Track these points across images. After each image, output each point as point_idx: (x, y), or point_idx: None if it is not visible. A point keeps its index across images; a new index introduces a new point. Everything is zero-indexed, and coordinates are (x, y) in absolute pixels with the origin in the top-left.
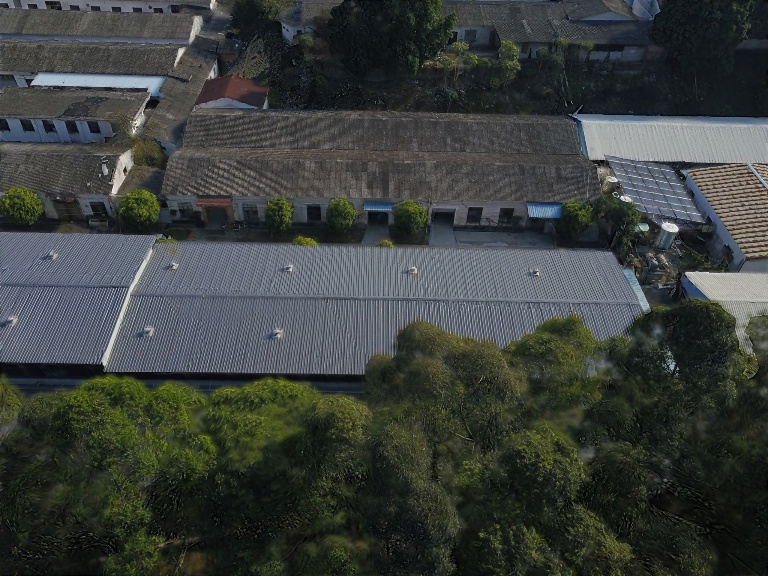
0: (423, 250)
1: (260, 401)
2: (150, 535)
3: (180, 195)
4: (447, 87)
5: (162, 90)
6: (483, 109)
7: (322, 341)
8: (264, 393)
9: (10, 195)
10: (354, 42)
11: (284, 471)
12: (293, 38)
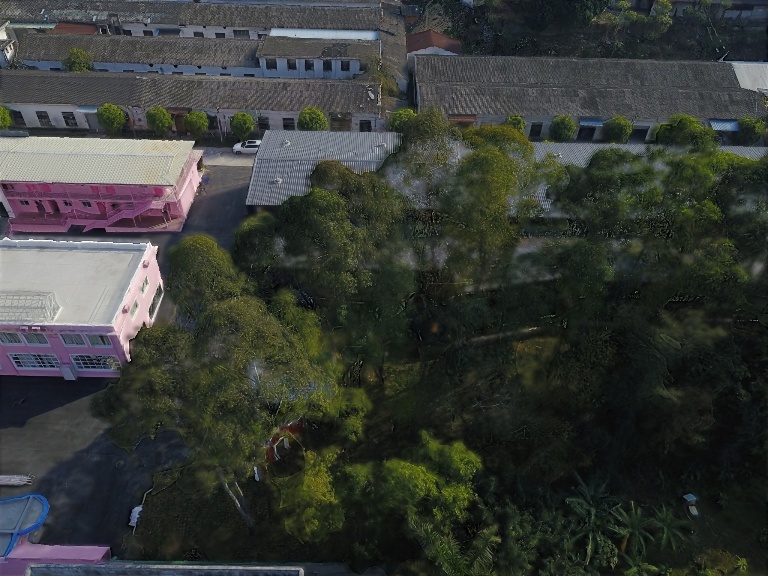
0: None
1: None
2: (715, 204)
3: None
4: (608, 40)
5: (381, 40)
6: (639, 58)
7: None
8: None
9: (308, 112)
10: None
11: None
12: (474, 1)
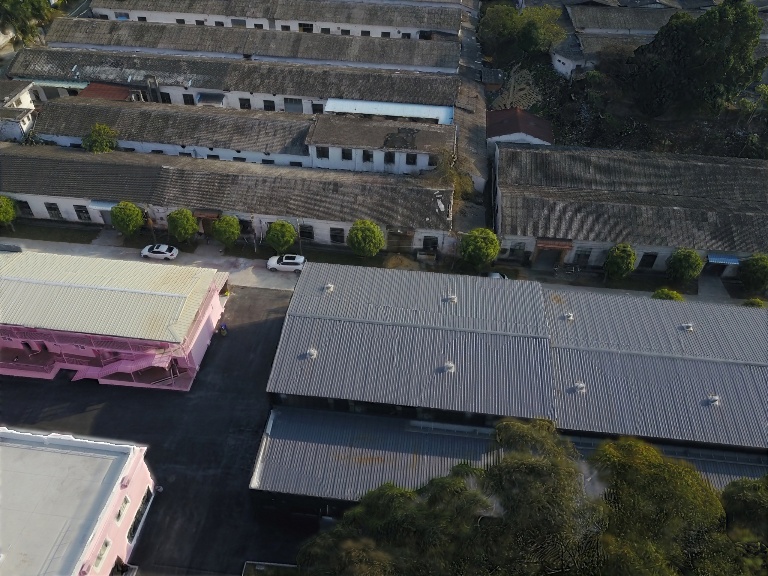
0: None
1: None
2: None
3: (520, 235)
4: (739, 130)
5: (456, 122)
6: None
7: (764, 412)
8: None
9: (361, 227)
10: (660, 82)
11: None
12: (571, 72)
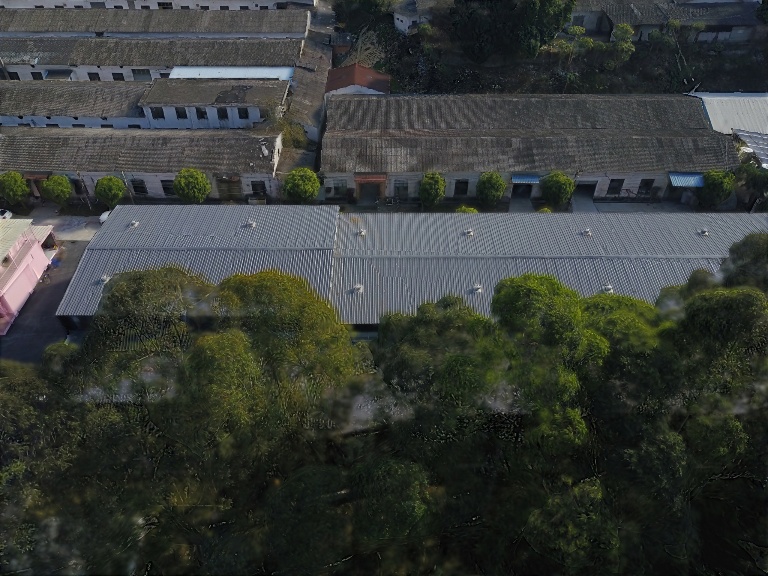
0: (589, 215)
1: (609, 308)
2: (574, 407)
3: (338, 172)
4: (561, 70)
5: (294, 79)
6: (598, 90)
7: None
8: (608, 302)
9: (184, 175)
10: (478, 28)
11: (675, 355)
12: (408, 28)
